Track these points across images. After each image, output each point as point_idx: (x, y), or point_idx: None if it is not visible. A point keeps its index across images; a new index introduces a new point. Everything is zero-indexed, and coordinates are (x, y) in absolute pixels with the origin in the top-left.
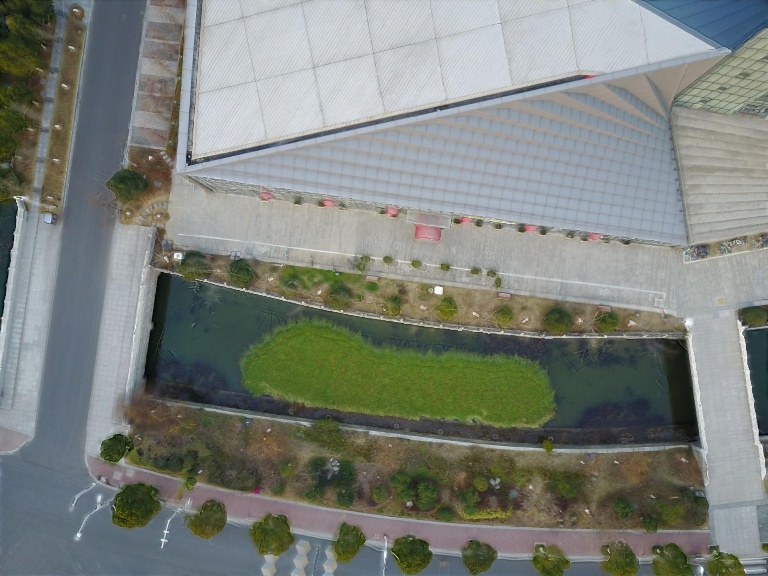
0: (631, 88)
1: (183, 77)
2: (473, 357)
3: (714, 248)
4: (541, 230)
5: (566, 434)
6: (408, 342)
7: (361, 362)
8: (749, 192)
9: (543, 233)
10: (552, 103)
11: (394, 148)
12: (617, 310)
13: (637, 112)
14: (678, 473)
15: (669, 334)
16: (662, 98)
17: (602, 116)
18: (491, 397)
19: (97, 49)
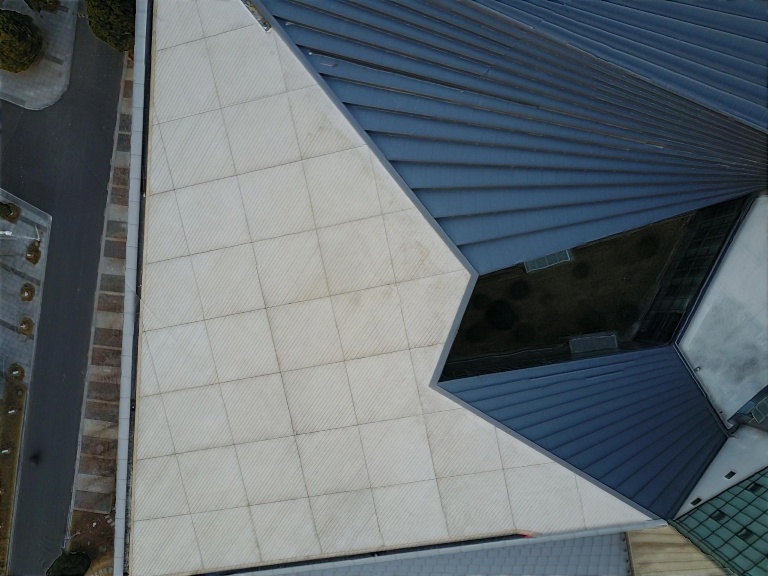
0: None
1: (117, 506)
2: None
3: None
4: None
5: None
6: None
7: None
8: (701, 568)
9: None
10: None
11: None
12: None
13: None
14: None
15: None
16: None
17: None
18: None
19: (38, 410)
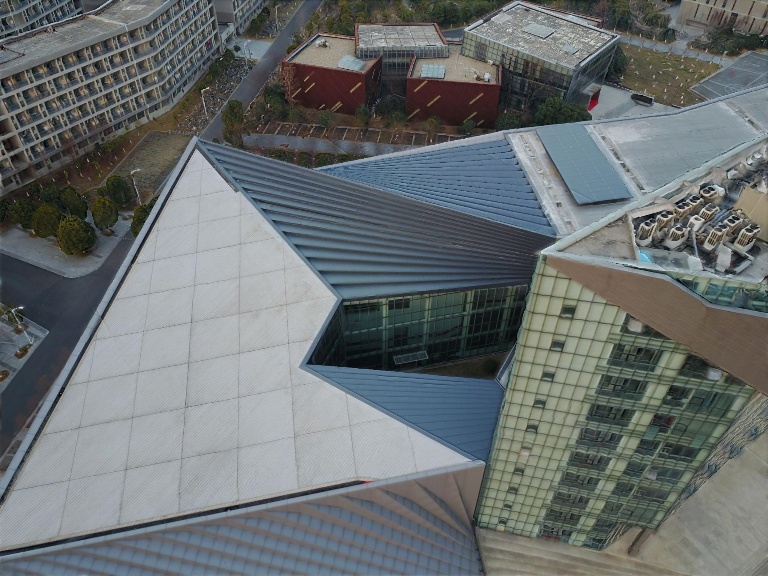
0: (415, 498)
1: (5, 475)
2: None
3: None
4: None
5: None
6: None
7: None
8: None
9: None
10: (341, 509)
11: (185, 551)
12: None
13: (430, 525)
14: None
15: None
16: (455, 514)
17: (395, 527)
18: None
19: None
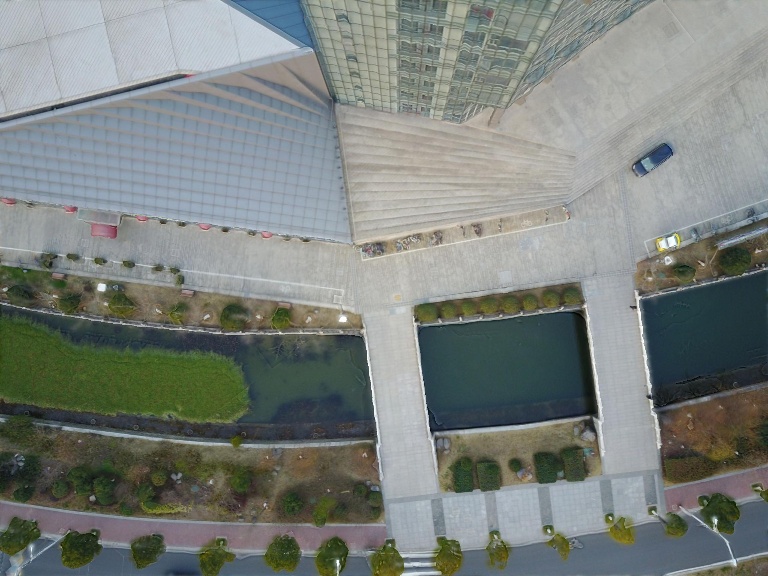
0: (251, 87)
1: None
2: (169, 353)
3: (391, 245)
4: (224, 227)
5: (259, 429)
6: (107, 339)
7: (59, 358)
8: (416, 190)
9: (225, 230)
10: (174, 102)
11: (32, 146)
12: (297, 307)
13: (276, 111)
14: (357, 468)
15: (345, 330)
16: (305, 97)
17: (238, 115)
18: (186, 393)
19: None
